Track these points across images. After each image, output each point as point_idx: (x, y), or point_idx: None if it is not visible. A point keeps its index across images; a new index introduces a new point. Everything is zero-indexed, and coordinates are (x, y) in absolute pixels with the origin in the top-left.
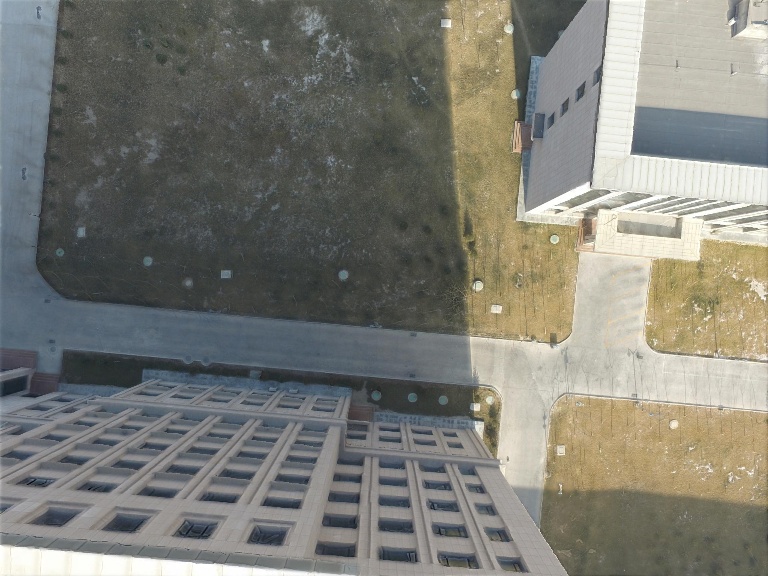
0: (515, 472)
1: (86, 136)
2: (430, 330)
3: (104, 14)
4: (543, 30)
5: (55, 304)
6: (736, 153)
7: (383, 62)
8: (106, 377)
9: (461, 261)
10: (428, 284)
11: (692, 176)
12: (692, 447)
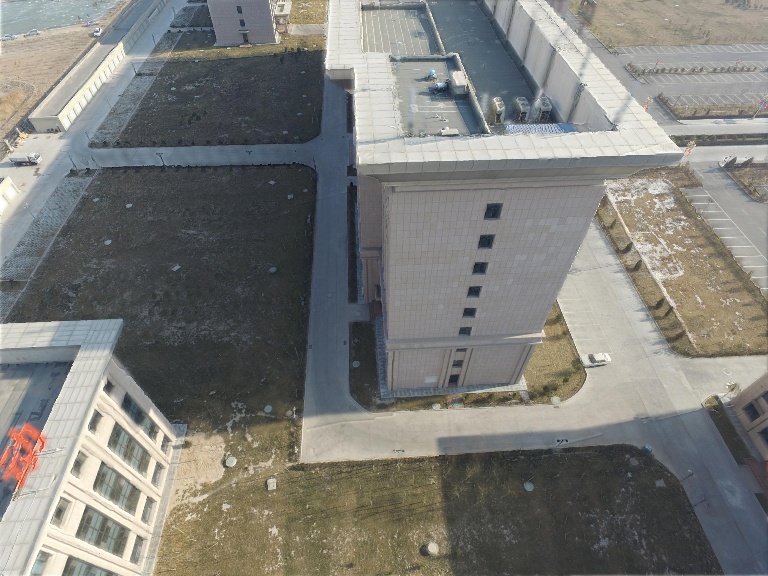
0: None
1: None
2: None
3: (171, 136)
4: (204, 45)
5: (324, 137)
6: None
7: None
8: None
9: None
10: None
11: None
12: None
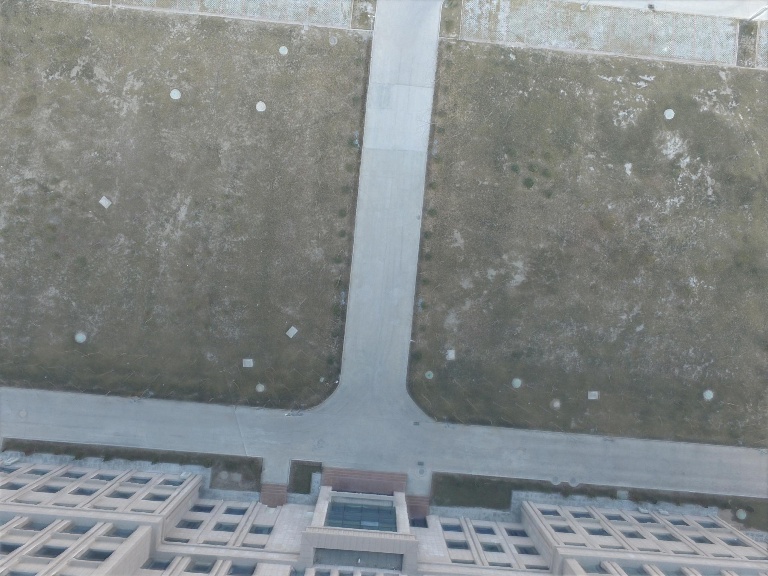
0: None
1: (454, 259)
2: None
3: (471, 139)
4: None
5: (424, 426)
6: None
7: (744, 185)
8: (474, 499)
9: None
10: None
11: None
12: None
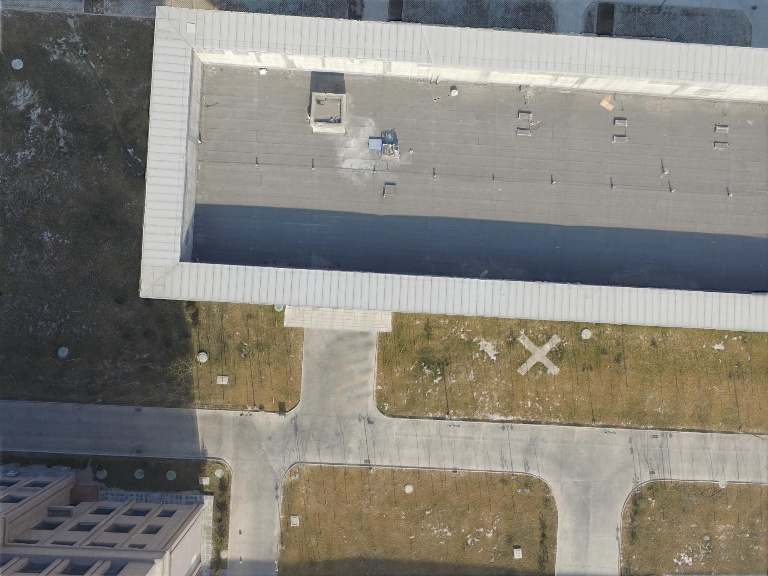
0: (248, 545)
1: None
2: (155, 404)
3: None
4: None
5: None
6: (324, 247)
7: (97, 135)
8: None
9: (185, 333)
10: (152, 357)
11: (243, 281)
12: (429, 511)
